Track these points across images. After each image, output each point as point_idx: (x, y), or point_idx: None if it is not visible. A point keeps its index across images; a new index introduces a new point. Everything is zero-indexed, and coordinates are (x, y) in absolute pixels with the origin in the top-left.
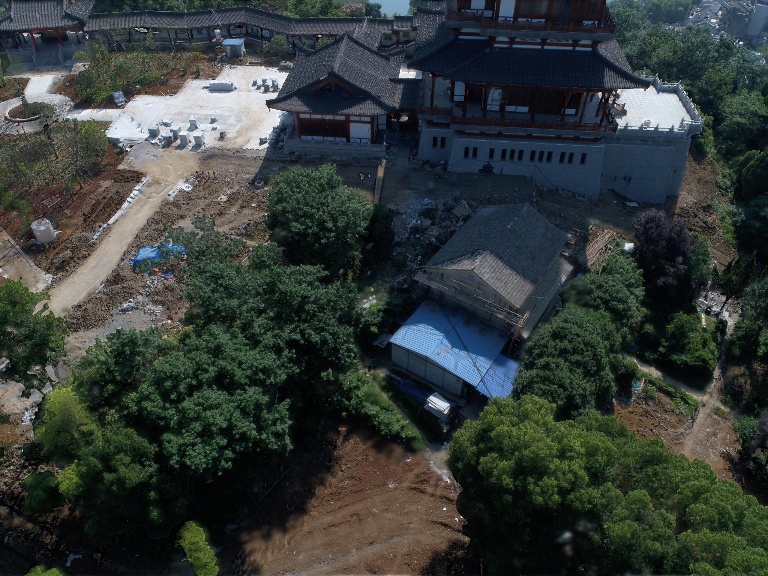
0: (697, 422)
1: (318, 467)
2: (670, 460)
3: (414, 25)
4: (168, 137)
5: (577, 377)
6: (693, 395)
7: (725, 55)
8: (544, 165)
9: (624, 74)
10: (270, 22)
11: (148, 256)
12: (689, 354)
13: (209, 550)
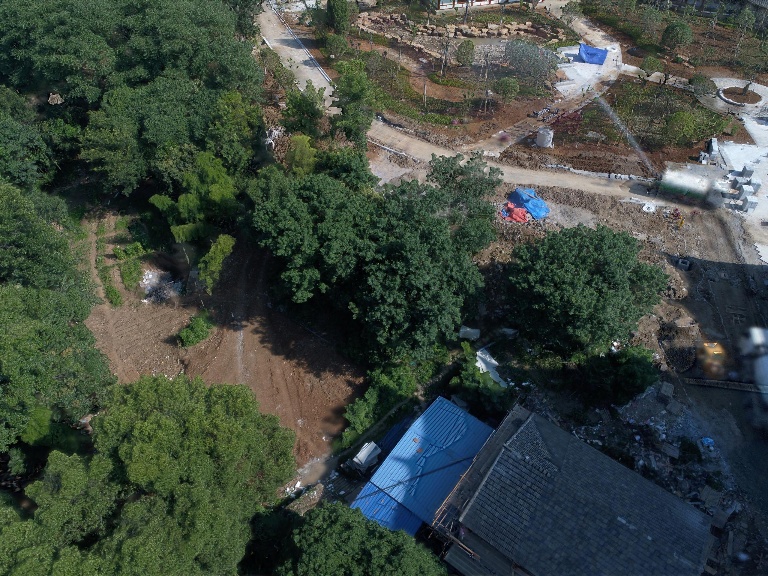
0: None
1: (324, 361)
2: (124, 573)
3: None
4: (737, 180)
5: (329, 569)
6: None
7: None
8: None
9: None
10: None
11: (522, 194)
12: None
13: (221, 258)
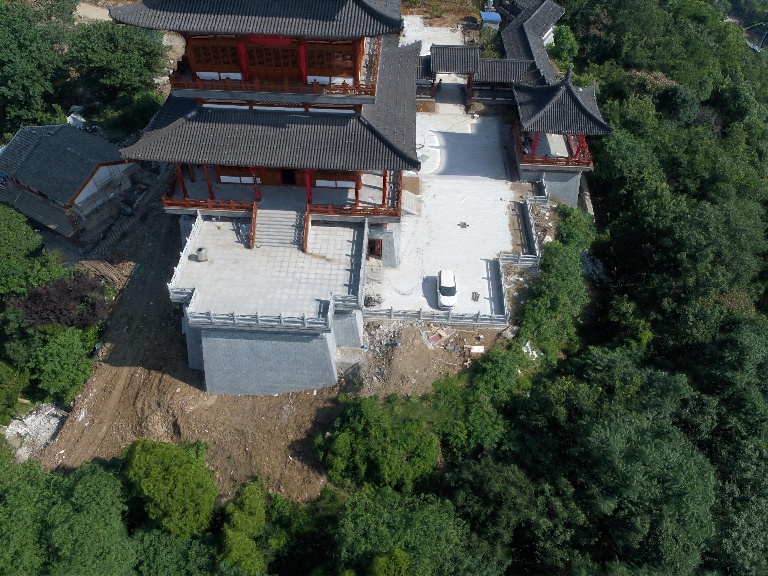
0: None
1: None
2: None
3: None
4: None
5: None
6: None
7: (616, 531)
8: None
9: None
10: None
11: None
12: None
13: None
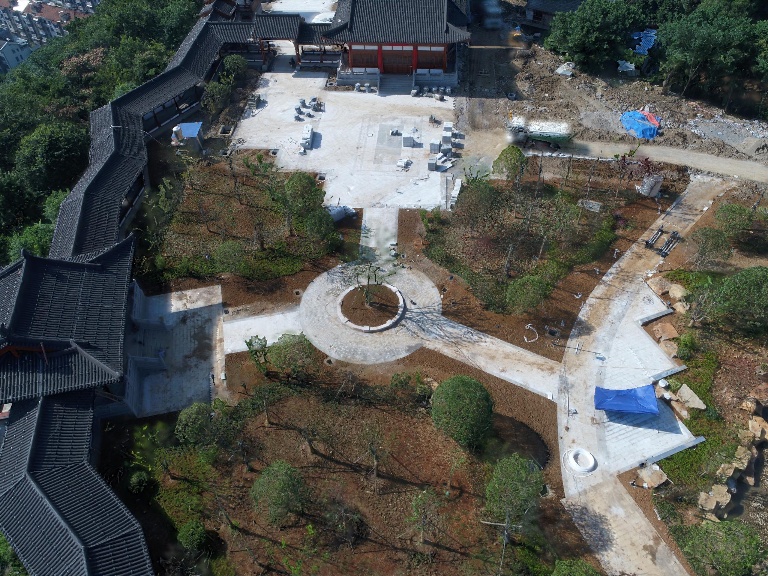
0: None
1: None
2: None
3: (235, 1)
4: None
5: None
6: None
7: None
8: None
9: None
10: (165, 90)
11: None
12: None
13: None
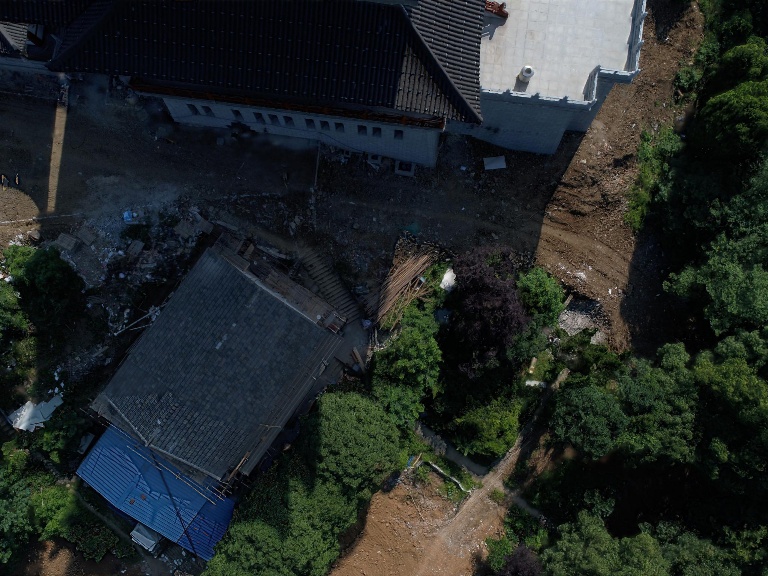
0: (463, 509)
1: None
2: None
3: None
4: None
5: None
6: (473, 474)
7: None
8: (334, 133)
9: (441, 75)
10: None
11: None
12: (479, 441)
13: None
